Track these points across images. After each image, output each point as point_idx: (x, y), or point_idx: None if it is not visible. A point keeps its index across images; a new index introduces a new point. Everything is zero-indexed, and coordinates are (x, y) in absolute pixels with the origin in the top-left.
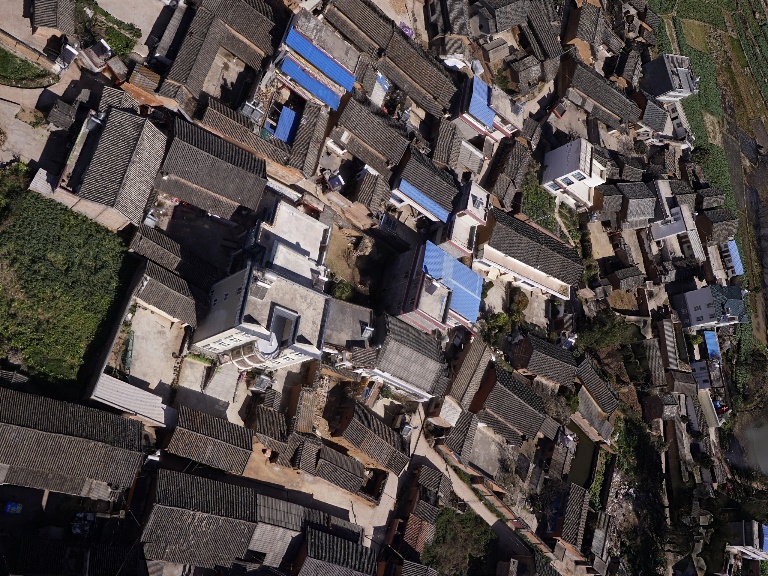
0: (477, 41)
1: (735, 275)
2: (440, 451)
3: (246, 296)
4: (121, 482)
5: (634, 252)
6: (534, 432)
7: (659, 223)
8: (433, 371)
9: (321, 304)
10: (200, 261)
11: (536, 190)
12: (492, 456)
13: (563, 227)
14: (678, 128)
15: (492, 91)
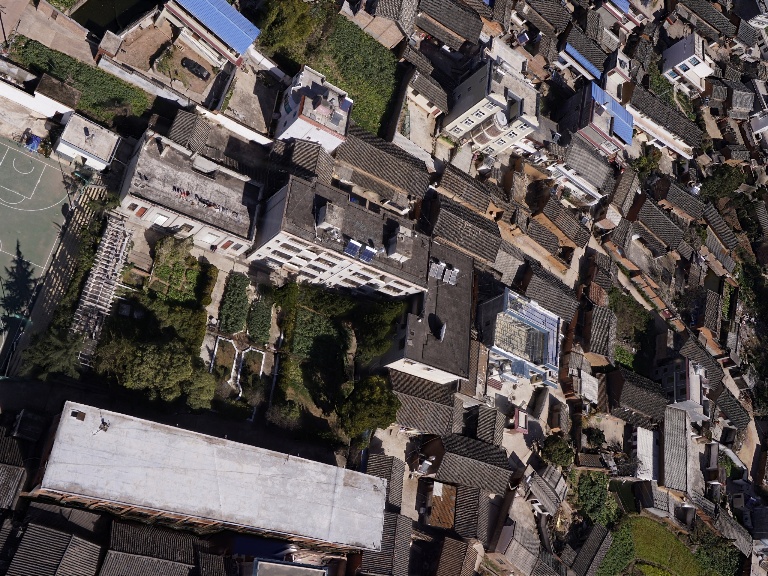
0: None
1: None
2: (606, 249)
3: (490, 78)
4: (417, 194)
5: (738, 140)
6: (676, 244)
7: (758, 116)
8: (604, 173)
9: (534, 96)
10: (444, 73)
11: (658, 77)
12: (643, 263)
13: (681, 108)
14: (765, 53)
15: None
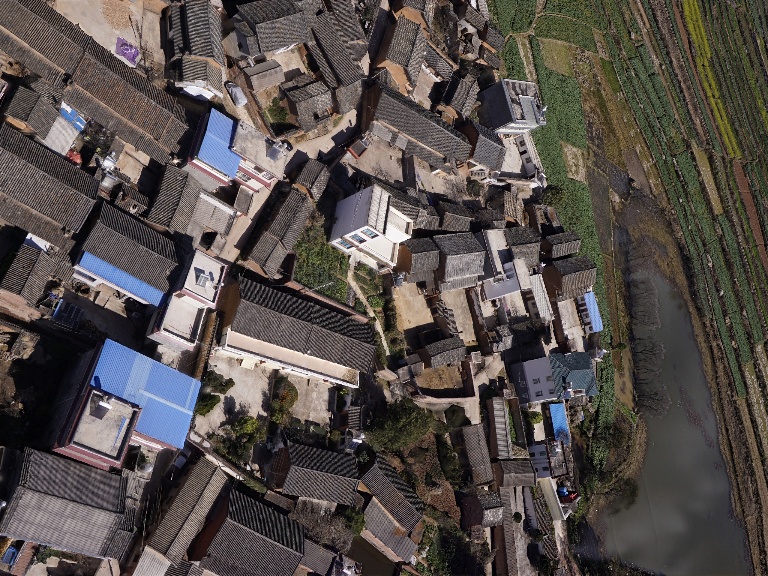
0: (237, 64)
1: (593, 332)
2: None
3: None
4: None
5: (461, 316)
6: (287, 575)
7: (491, 280)
8: (104, 525)
9: None
10: None
11: (321, 249)
12: None
13: (359, 293)
14: (527, 164)
15: (237, 129)
